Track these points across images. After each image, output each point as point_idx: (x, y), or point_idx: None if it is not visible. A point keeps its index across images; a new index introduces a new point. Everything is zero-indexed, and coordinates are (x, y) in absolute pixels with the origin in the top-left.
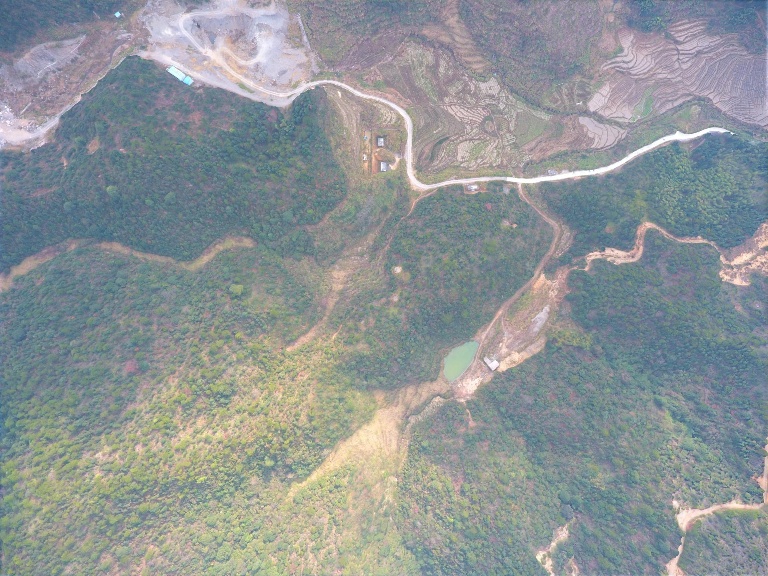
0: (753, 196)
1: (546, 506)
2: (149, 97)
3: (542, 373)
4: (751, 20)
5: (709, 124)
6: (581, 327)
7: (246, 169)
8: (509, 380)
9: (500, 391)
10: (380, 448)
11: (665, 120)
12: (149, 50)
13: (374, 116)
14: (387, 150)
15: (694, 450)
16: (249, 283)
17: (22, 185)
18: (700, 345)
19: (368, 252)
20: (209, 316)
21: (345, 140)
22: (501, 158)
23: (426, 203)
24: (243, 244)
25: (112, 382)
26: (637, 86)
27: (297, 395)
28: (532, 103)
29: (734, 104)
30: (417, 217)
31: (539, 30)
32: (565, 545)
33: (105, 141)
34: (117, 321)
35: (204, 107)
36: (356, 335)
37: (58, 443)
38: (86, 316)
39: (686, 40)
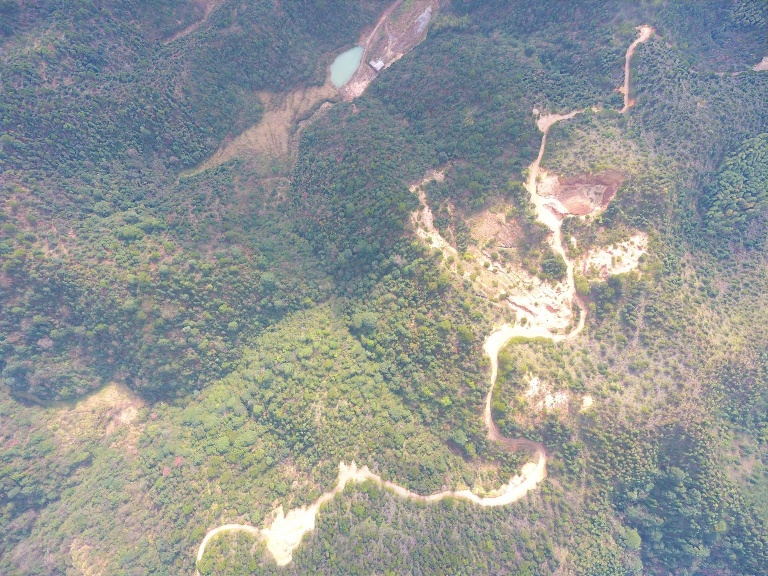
0: None
1: (422, 156)
2: None
3: (420, 53)
4: None
5: None
6: None
7: None
8: (391, 70)
9: (382, 80)
10: (270, 149)
11: None
12: None
13: None
14: None
15: (561, 80)
16: None
17: None
18: None
19: None
20: None
21: None
22: None
23: None
24: None
25: None
26: None
27: (170, 70)
28: None
29: None
30: None
31: None
32: (440, 185)
33: None
34: None
35: None
36: None
37: None
38: None
39: None
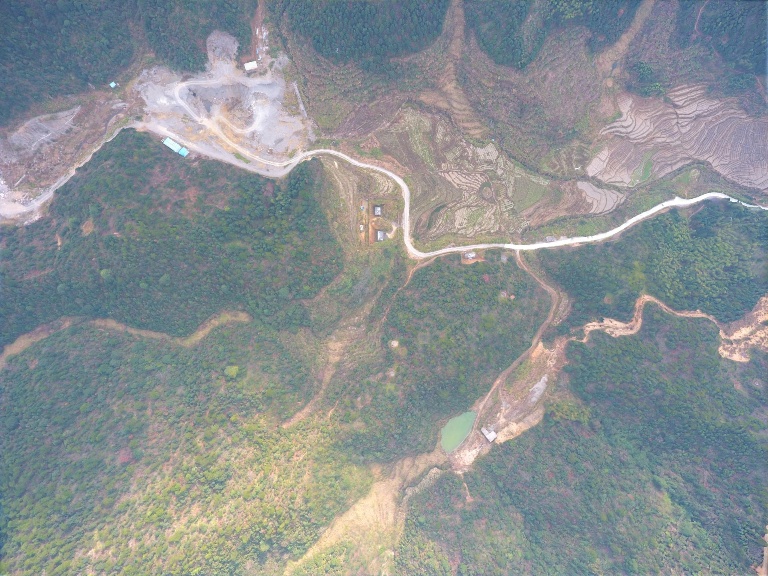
0: (753, 268)
1: None
2: (144, 174)
3: (540, 448)
4: (751, 85)
5: (708, 189)
6: (579, 399)
7: (241, 248)
8: (507, 454)
9: (498, 465)
10: (377, 522)
11: (664, 184)
12: (144, 121)
13: (371, 186)
14: (384, 218)
15: (693, 536)
16: (244, 363)
17: (15, 267)
18: (699, 427)
19: (365, 322)
20: (204, 399)
21: (342, 212)
22: (499, 224)
23: (423, 274)
24: (239, 319)
25: (105, 474)
26: (636, 150)
27: (293, 477)
28: (530, 168)
29: (733, 168)
30: (414, 289)
31: (537, 98)
32: None
33: (99, 224)
34: (111, 407)
35: (199, 182)
36: (352, 413)
37: (50, 543)
38: (80, 401)
39: (685, 104)
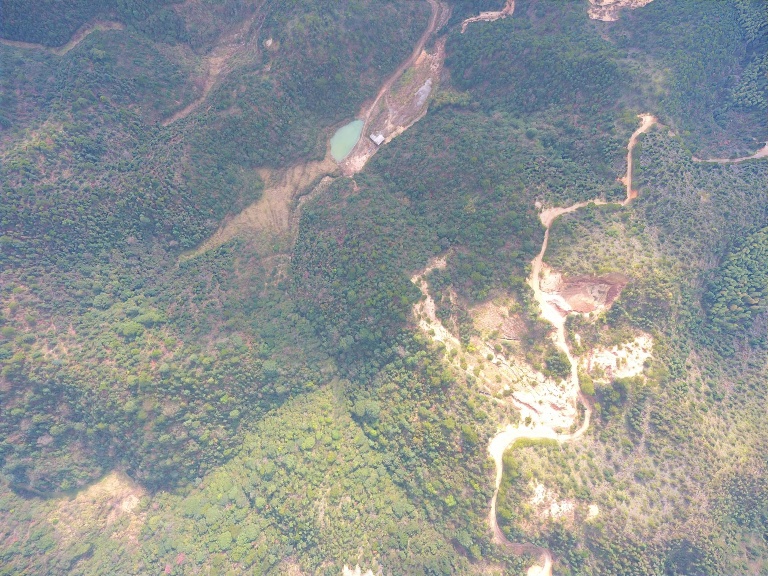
0: None
1: (423, 241)
2: None
3: (421, 131)
4: None
5: None
6: (462, 92)
7: None
8: (392, 146)
9: (383, 157)
10: (270, 226)
11: None
12: None
13: None
14: None
15: (563, 167)
16: (114, 53)
17: None
18: (564, 68)
19: (244, 38)
20: None
21: None
22: None
23: None
24: None
25: None
26: None
27: (169, 156)
28: None
29: None
30: None
31: None
32: (442, 273)
33: None
34: None
35: None
36: None
37: None
38: None
39: None
